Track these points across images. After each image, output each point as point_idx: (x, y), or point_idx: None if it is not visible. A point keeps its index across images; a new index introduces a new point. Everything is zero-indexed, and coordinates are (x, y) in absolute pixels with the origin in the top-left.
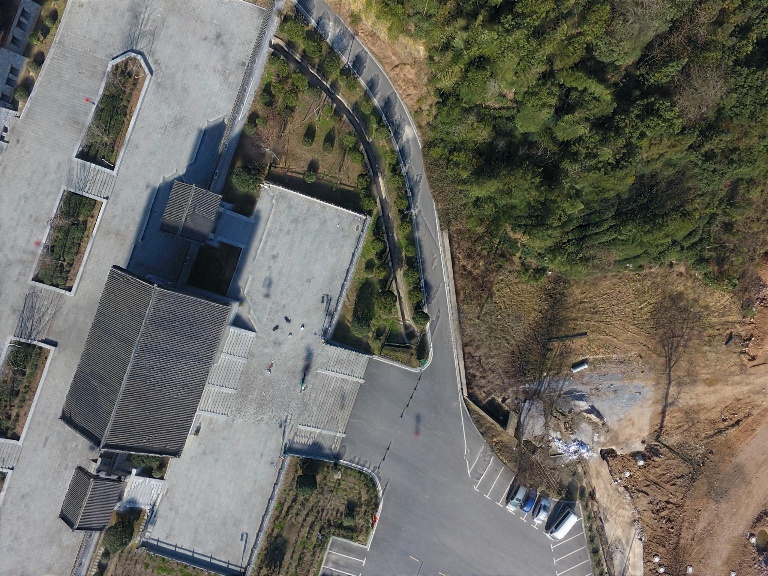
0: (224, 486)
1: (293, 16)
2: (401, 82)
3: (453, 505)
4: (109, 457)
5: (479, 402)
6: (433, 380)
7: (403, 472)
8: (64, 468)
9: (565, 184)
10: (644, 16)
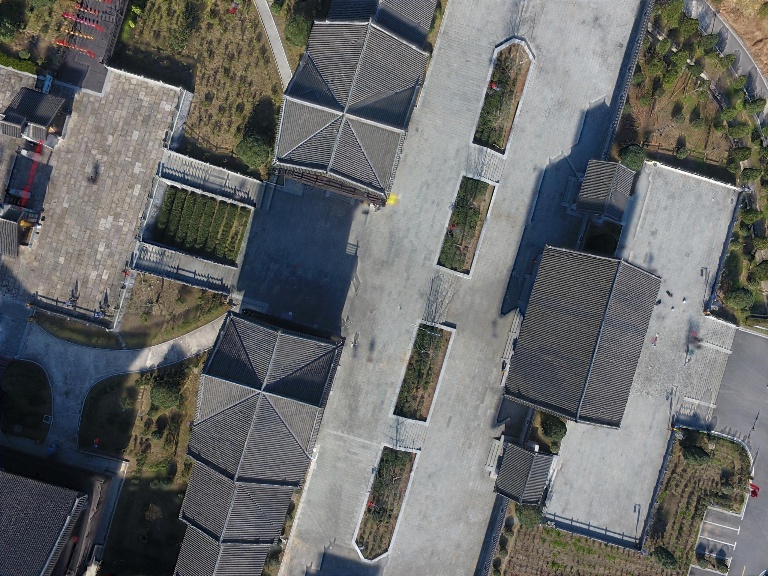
0: (616, 459)
1: None
2: (763, 56)
3: None
4: (510, 435)
5: None
6: None
7: None
8: (468, 447)
9: None
10: None
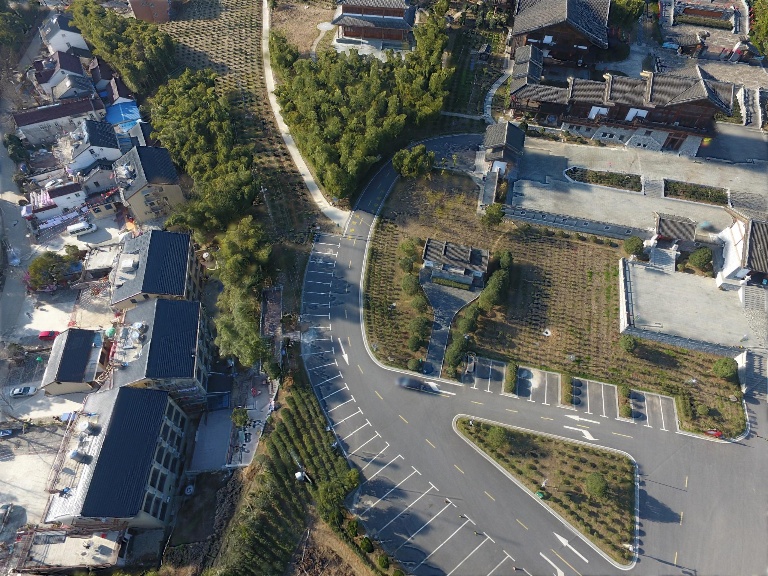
0: (691, 309)
1: None
2: None
3: (759, 522)
4: None
5: None
6: None
7: (765, 461)
8: None
9: None
10: None
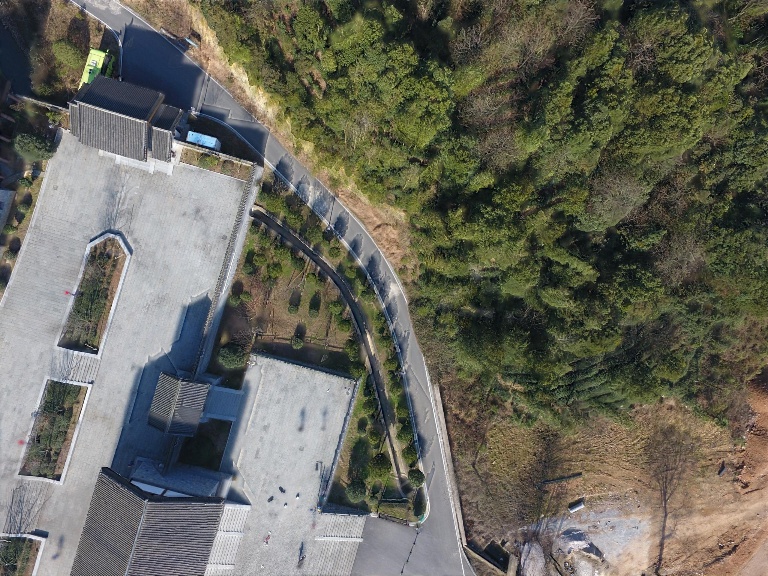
0: None
1: (272, 182)
2: (384, 241)
3: None
4: None
5: (479, 548)
6: (432, 533)
7: None
8: None
9: (553, 351)
10: (622, 200)
